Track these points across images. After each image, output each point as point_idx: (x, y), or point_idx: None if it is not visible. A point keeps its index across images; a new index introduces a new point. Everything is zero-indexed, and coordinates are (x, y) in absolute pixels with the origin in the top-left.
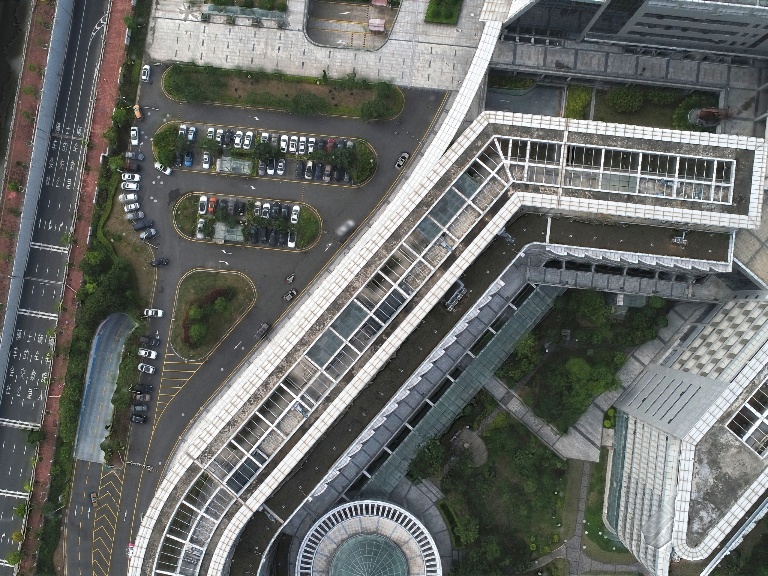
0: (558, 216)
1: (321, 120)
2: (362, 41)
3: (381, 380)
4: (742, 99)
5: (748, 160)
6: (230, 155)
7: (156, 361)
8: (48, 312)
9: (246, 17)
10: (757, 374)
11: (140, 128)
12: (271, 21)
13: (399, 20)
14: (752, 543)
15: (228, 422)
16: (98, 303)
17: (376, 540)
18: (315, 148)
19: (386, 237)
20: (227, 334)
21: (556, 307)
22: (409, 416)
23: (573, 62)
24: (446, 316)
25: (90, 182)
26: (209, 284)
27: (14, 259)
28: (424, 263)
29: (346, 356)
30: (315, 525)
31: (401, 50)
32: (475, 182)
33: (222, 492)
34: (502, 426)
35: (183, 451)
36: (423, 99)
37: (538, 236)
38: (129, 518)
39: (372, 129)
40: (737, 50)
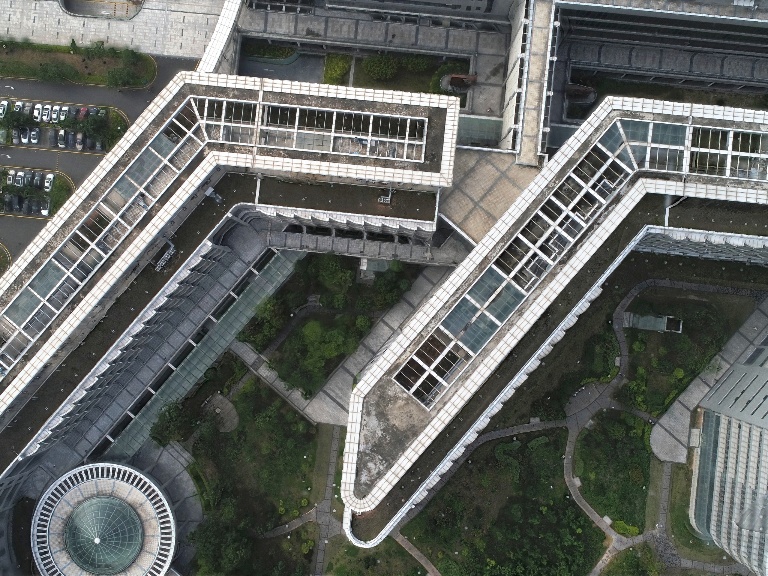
0: (261, 176)
1: (74, 89)
2: (125, 11)
3: (93, 341)
4: (490, 65)
5: (440, 118)
6: None
7: None
8: None
9: None
10: (424, 327)
11: None
12: None
13: None
14: (498, 505)
15: None
16: None
17: (110, 502)
18: (68, 117)
19: (83, 197)
20: None
21: (296, 271)
22: (151, 380)
23: (323, 29)
24: (157, 277)
25: None
26: None
27: None
28: (121, 222)
29: (44, 315)
30: (50, 488)
31: (154, 19)
32: (172, 142)
33: None
34: (250, 391)
35: None
36: (175, 67)
37: (248, 197)
38: None
39: (125, 97)
40: (475, 15)
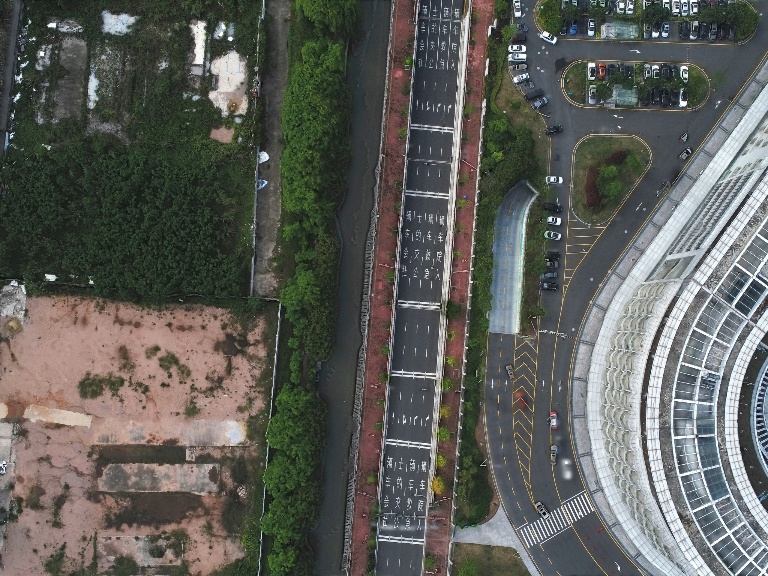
0: None
1: None
2: None
3: None
4: None
5: None
6: (612, 21)
7: (560, 228)
8: (435, 192)
9: None
10: None
11: (520, 1)
12: None
13: None
14: None
15: (730, 246)
16: (515, 167)
17: None
18: (698, 8)
19: None
20: (627, 197)
21: None
22: None
23: None
24: None
25: (476, 56)
26: (605, 148)
27: (406, 137)
28: None
29: None
30: None
31: None
32: None
33: (732, 315)
34: None
35: (612, 309)
36: None
37: None
38: (547, 387)
39: None
40: None
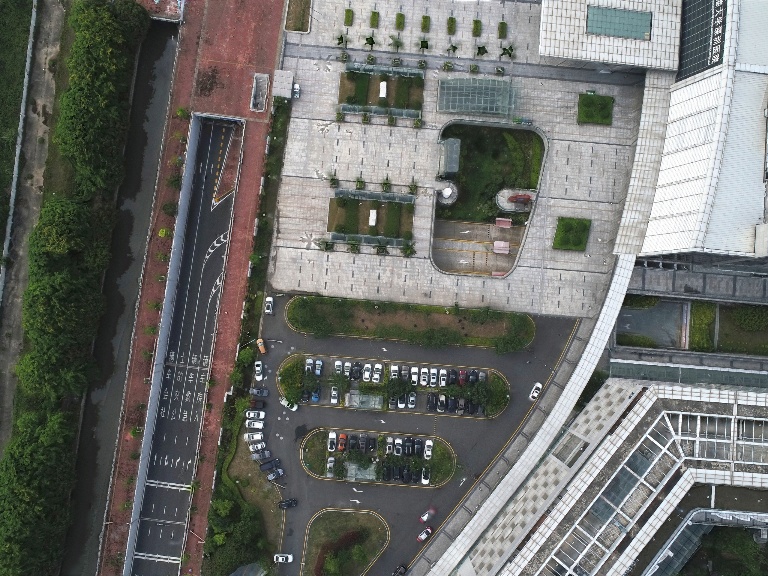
0: (726, 485)
1: (452, 351)
2: (484, 260)
3: None
4: None
5: None
6: (358, 388)
7: None
8: (166, 555)
9: (371, 245)
10: None
11: (263, 362)
12: (396, 249)
13: (527, 246)
14: None
15: None
16: (231, 560)
17: None
18: (447, 380)
19: (559, 520)
20: None
21: (703, 546)
22: None
23: (702, 286)
24: None
25: (212, 420)
26: (340, 525)
27: (133, 505)
28: (599, 546)
29: None
30: None
31: (530, 277)
32: (646, 459)
33: None
34: None
35: None
36: (554, 327)
37: (703, 500)
38: None
39: (504, 359)
40: None
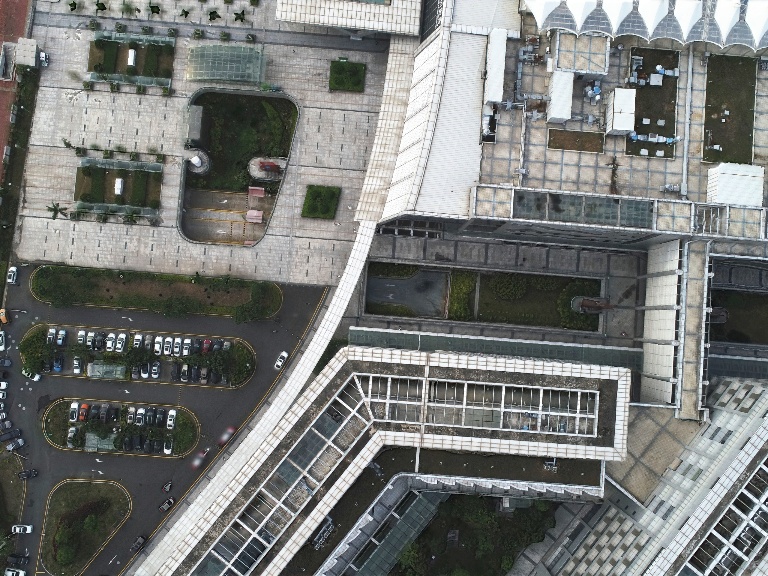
0: (425, 448)
1: (197, 320)
2: (242, 230)
3: None
4: (623, 287)
5: (611, 390)
6: (102, 358)
7: None
8: None
9: (117, 214)
10: None
11: (7, 332)
12: (144, 218)
13: (275, 215)
14: None
15: None
16: None
17: None
18: (191, 350)
19: (244, 483)
20: (101, 548)
21: (440, 514)
22: None
23: (453, 254)
24: (314, 553)
25: None
26: (81, 496)
27: None
28: (284, 509)
29: None
30: None
31: (278, 245)
32: (335, 421)
33: None
34: None
35: None
36: (302, 295)
37: (407, 465)
38: None
39: (250, 328)
40: (612, 245)
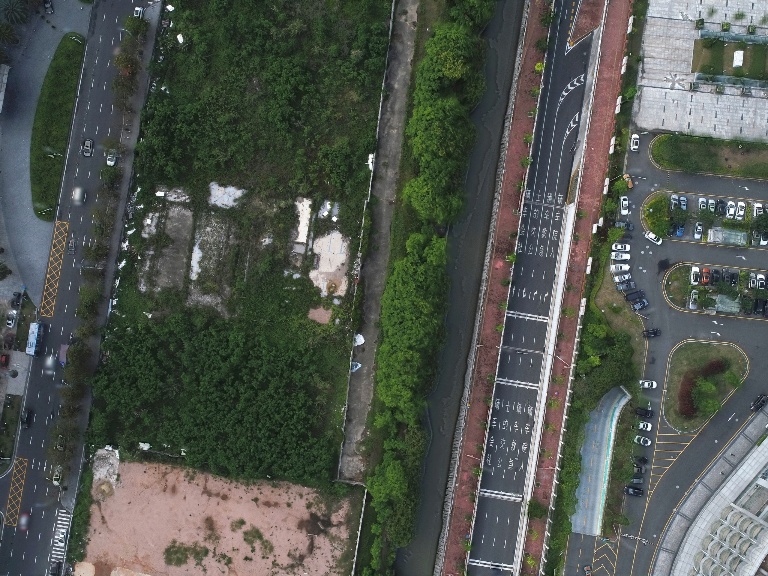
0: None
1: None
2: None
3: None
4: None
5: None
6: (720, 225)
7: (649, 433)
8: (526, 381)
9: (735, 86)
10: None
11: (628, 197)
12: (760, 90)
13: None
14: None
15: None
16: (612, 377)
17: None
18: None
19: None
20: None
21: None
22: None
23: None
24: None
25: (579, 252)
26: (702, 355)
27: (502, 329)
28: None
29: None
30: None
31: None
32: None
33: None
34: None
35: (698, 527)
36: None
37: None
38: None
39: None
40: None
